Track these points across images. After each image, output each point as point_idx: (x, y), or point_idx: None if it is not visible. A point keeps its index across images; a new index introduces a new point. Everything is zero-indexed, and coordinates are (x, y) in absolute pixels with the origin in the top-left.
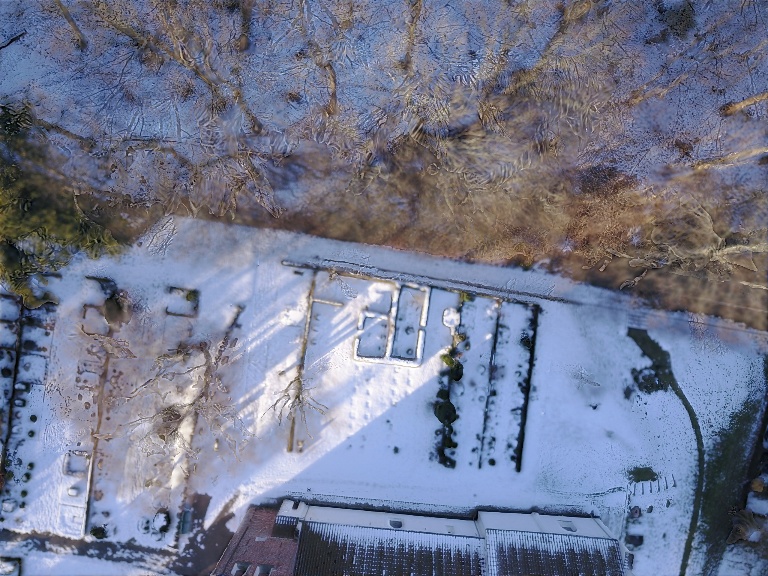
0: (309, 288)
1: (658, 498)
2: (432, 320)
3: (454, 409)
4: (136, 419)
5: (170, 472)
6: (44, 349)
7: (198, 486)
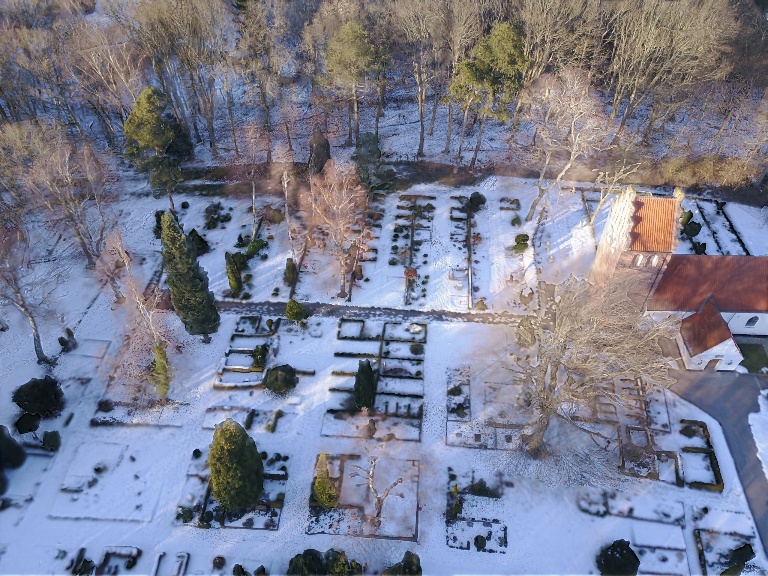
0: (581, 197)
1: None
2: None
3: None
4: (493, 253)
5: (523, 275)
6: (428, 227)
7: (545, 279)
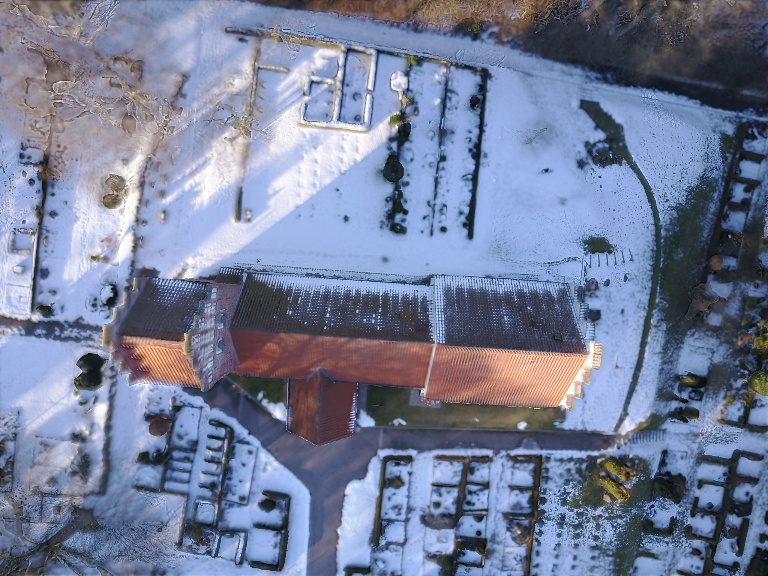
0: (254, 56)
1: (615, 271)
2: (380, 86)
3: (402, 166)
4: (82, 195)
5: (117, 247)
6: None
7: (146, 260)
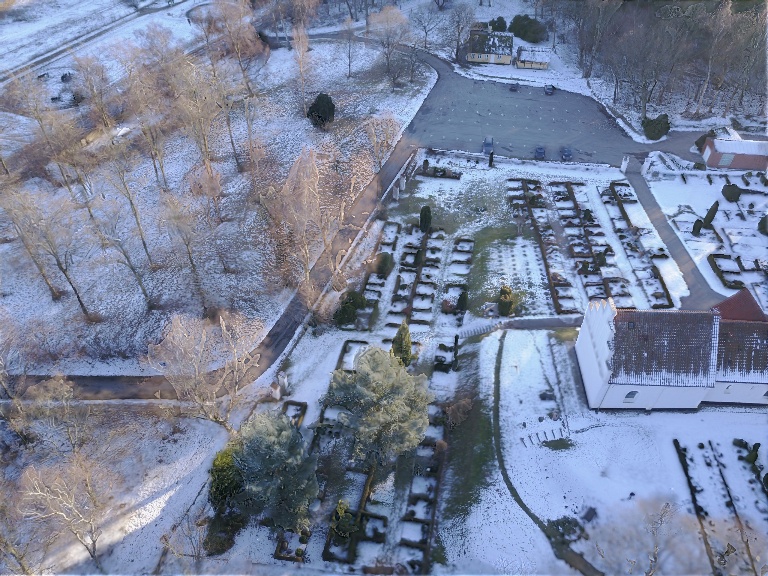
0: None
1: (536, 428)
2: None
3: None
4: None
5: None
6: None
7: None
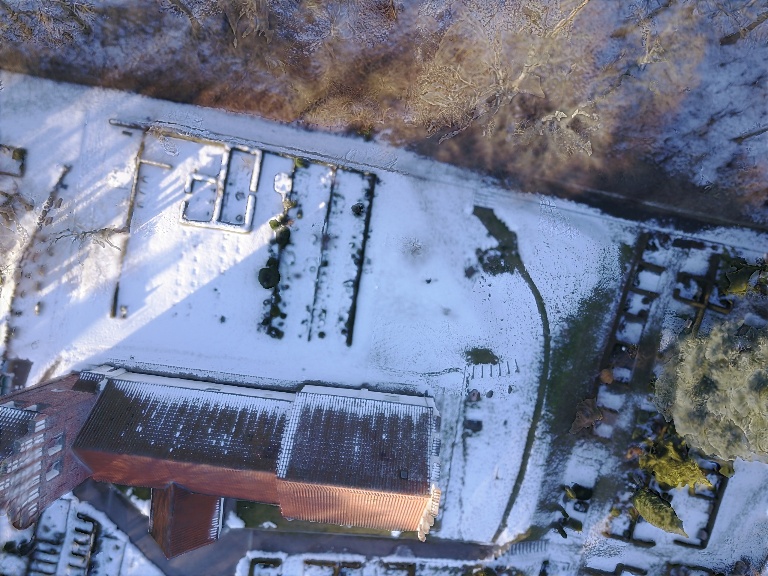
0: (138, 149)
1: (499, 383)
2: (263, 186)
3: (277, 273)
4: None
5: None
6: None
7: (19, 350)
